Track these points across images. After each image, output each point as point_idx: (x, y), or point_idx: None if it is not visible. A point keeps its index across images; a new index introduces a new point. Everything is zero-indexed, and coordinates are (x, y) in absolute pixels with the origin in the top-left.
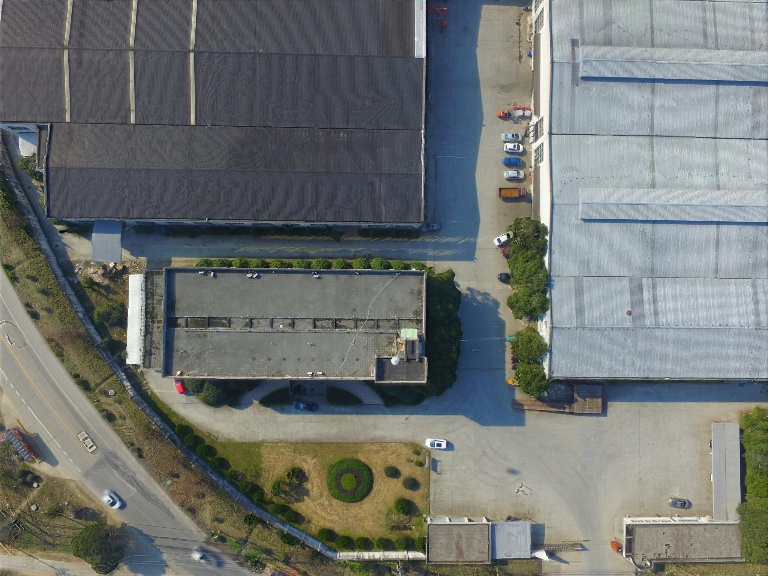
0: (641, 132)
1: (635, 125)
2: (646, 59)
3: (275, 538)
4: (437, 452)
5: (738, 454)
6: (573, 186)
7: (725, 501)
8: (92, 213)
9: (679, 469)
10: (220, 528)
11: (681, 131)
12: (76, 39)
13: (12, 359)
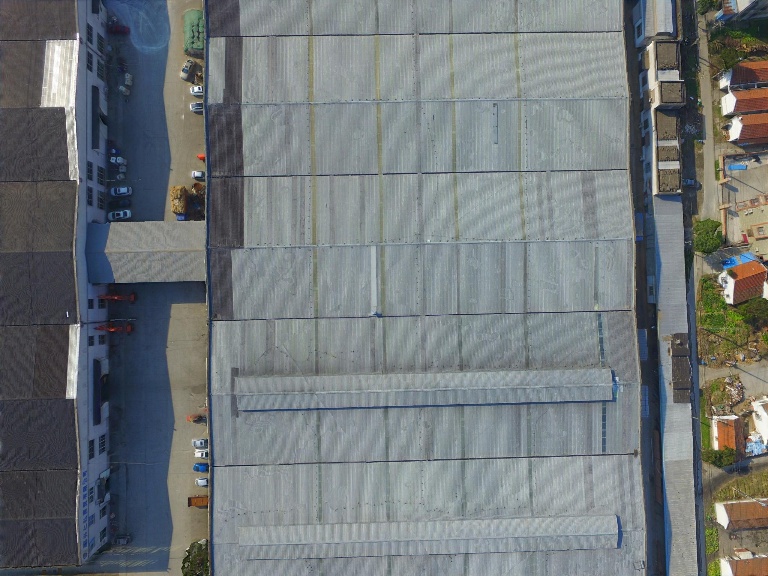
0: (308, 460)
1: (301, 453)
2: (304, 390)
3: None
4: None
5: None
6: (234, 523)
7: None
8: None
9: None
10: None
11: (350, 457)
12: None
13: None
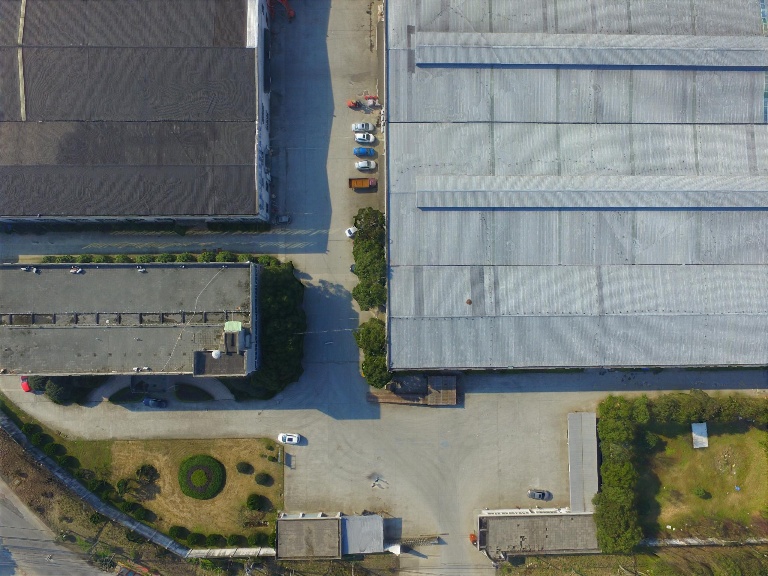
0: (481, 118)
1: (474, 112)
2: (482, 44)
3: None
4: (291, 447)
5: (595, 444)
6: (410, 174)
7: (583, 492)
8: None
9: (539, 460)
10: (69, 527)
11: (522, 117)
12: None
13: None
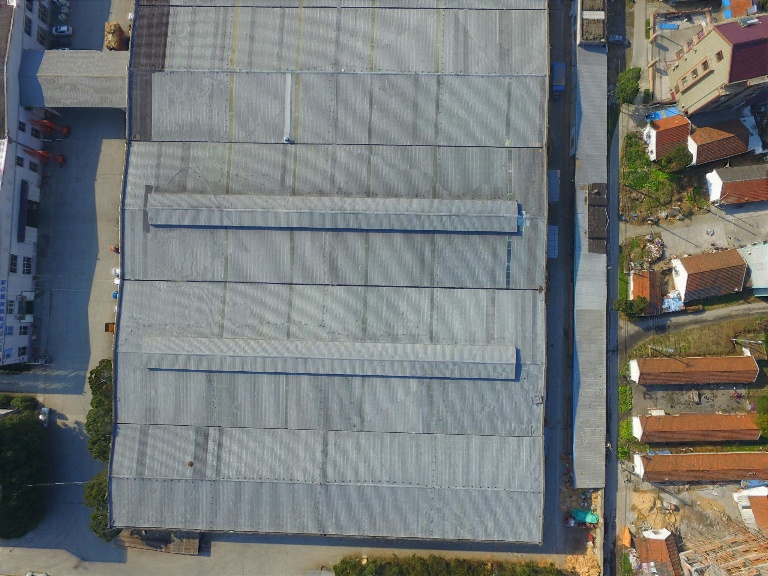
0: (215, 278)
1: (208, 271)
2: (213, 207)
3: None
4: None
5: None
6: (139, 334)
7: None
8: None
9: None
10: None
11: (255, 277)
12: None
13: None
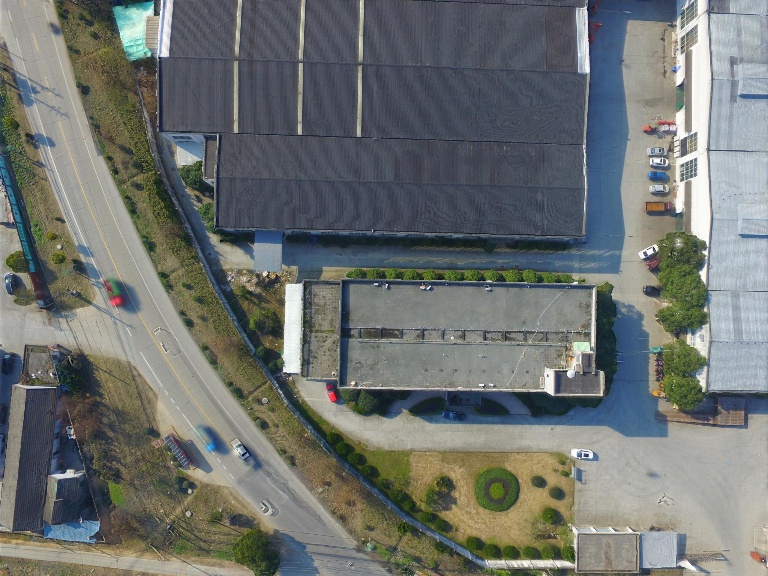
0: None
1: None
2: None
3: (424, 546)
4: (582, 462)
5: None
6: (731, 202)
7: None
8: (260, 223)
9: None
10: (371, 535)
11: None
12: (246, 50)
13: (167, 366)
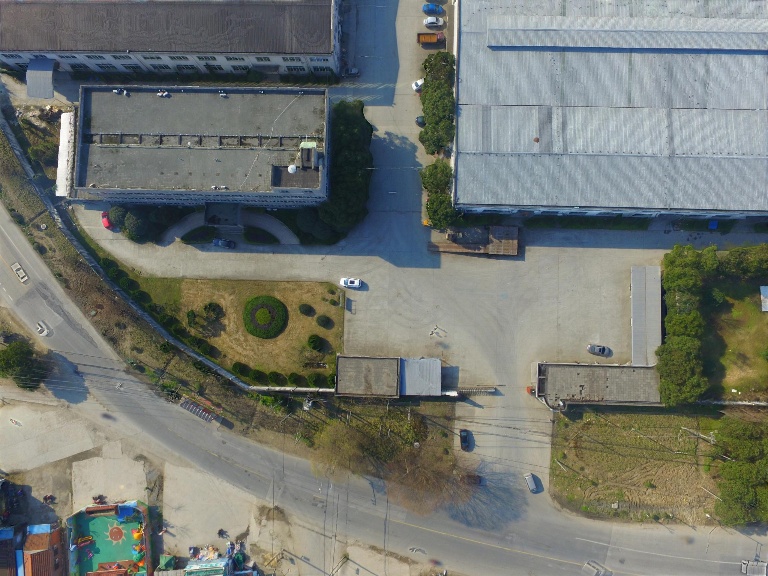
0: None
1: None
2: None
3: (191, 370)
4: (352, 292)
5: (659, 297)
6: (481, 16)
7: (645, 346)
8: (24, 46)
9: (600, 316)
10: (139, 358)
11: None
12: None
13: None
